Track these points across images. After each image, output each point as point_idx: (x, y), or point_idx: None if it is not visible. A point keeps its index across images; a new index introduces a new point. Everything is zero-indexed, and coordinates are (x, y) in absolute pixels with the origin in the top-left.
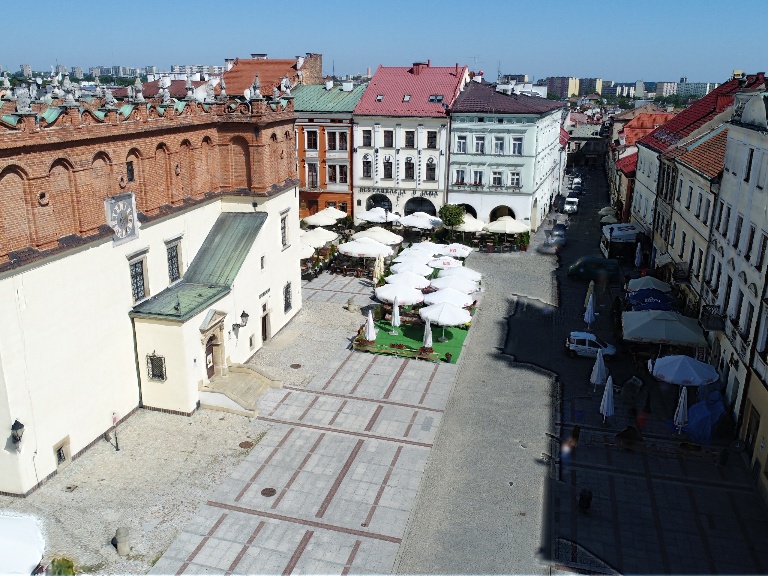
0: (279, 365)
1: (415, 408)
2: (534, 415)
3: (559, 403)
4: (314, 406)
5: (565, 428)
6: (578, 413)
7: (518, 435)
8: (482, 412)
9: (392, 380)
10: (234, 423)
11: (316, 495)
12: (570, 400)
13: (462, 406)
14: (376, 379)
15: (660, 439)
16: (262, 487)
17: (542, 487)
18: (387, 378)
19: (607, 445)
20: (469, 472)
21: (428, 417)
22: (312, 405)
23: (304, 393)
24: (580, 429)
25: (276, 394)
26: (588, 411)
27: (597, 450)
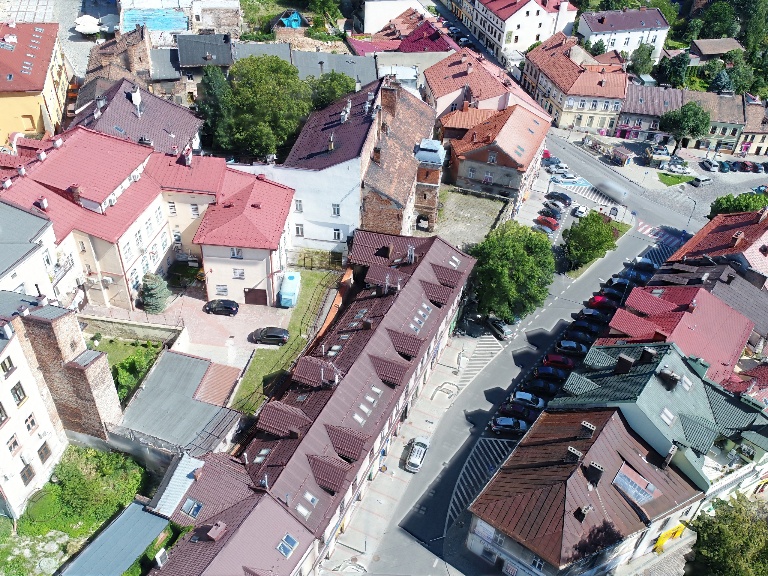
0: (4, 2)
1: (46, 6)
2: (76, 4)
3: (82, 1)
4: (20, 8)
5: (83, 5)
6: (87, 2)
7: (73, 7)
8: (63, 5)
9: (38, 2)
10: (3, 13)
11: (31, 19)
12: (85, 0)
13: (58, 4)
14: (33, 2)
15: (105, 4)
16: (19, 20)
17: (78, 13)
18: (36, 1)
19: (93, 6)
20: (62, 13)
21: (50, 7)
22: (20, 8)
23: (16, 6)
24: (87, 4)
25: (8, 7)
26: (89, 1)
27: (90, 7)
